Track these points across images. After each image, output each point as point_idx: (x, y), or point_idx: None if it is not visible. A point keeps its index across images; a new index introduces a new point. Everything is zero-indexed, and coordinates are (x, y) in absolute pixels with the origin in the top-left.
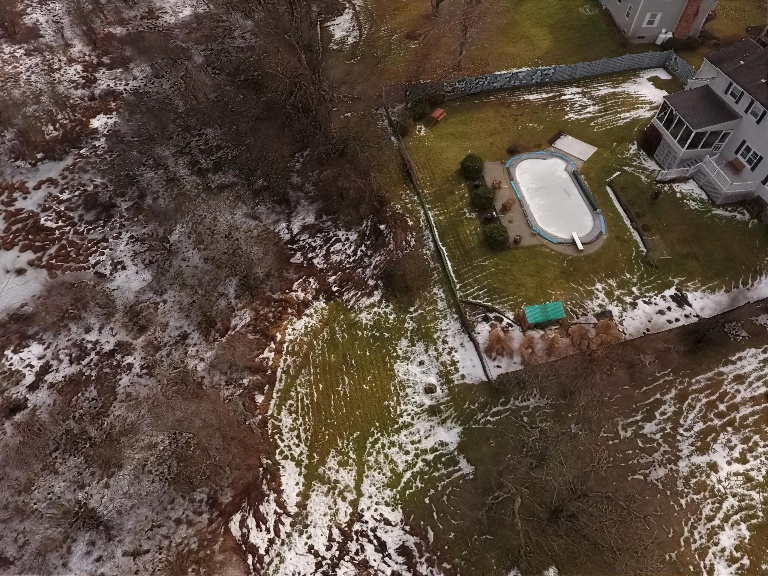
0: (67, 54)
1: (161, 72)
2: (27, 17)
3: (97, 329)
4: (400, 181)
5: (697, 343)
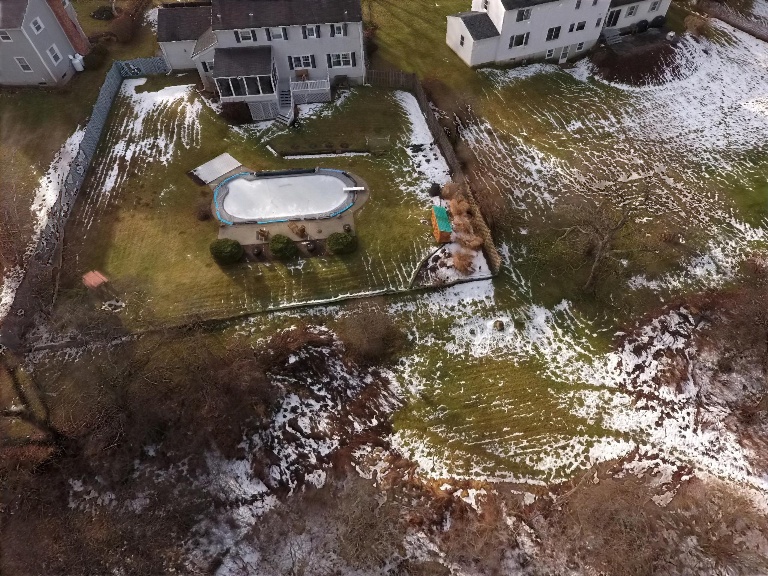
0: None
1: None
2: None
3: None
4: (213, 336)
5: (454, 151)
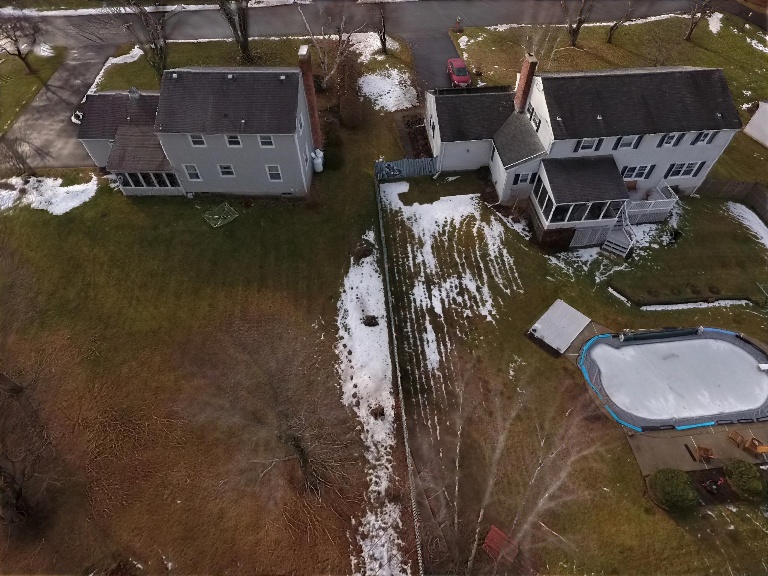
0: None
1: None
2: None
3: None
4: None
5: None
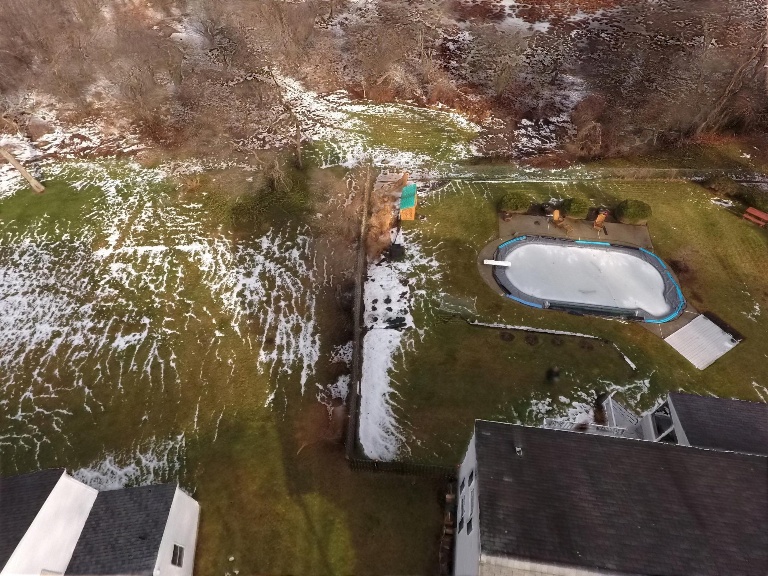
0: None
1: None
2: None
3: None
4: None
5: None
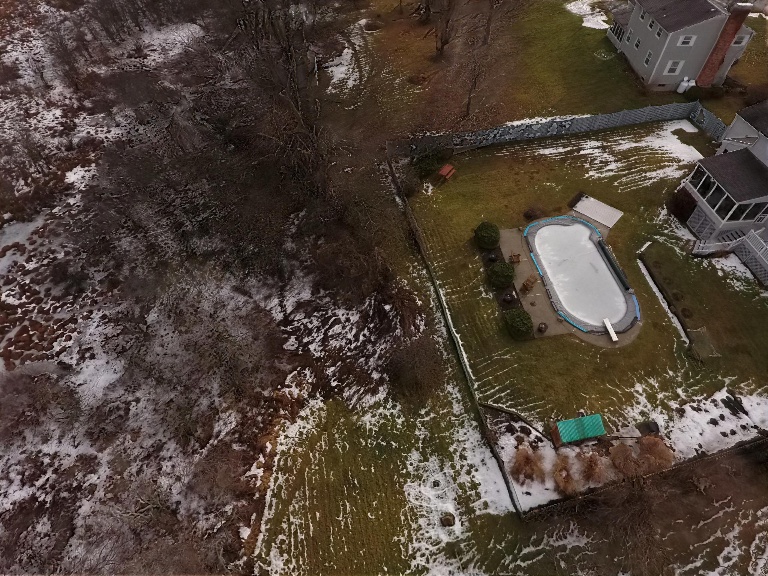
0: (46, 97)
1: (146, 118)
2: (6, 55)
3: (57, 438)
4: (406, 250)
5: (759, 463)
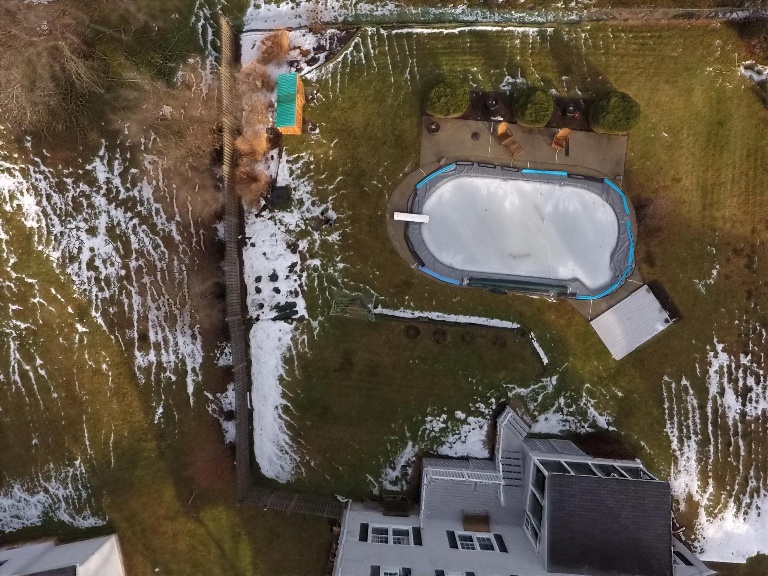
0: None
1: None
2: None
3: None
4: (623, 2)
5: (222, 295)
